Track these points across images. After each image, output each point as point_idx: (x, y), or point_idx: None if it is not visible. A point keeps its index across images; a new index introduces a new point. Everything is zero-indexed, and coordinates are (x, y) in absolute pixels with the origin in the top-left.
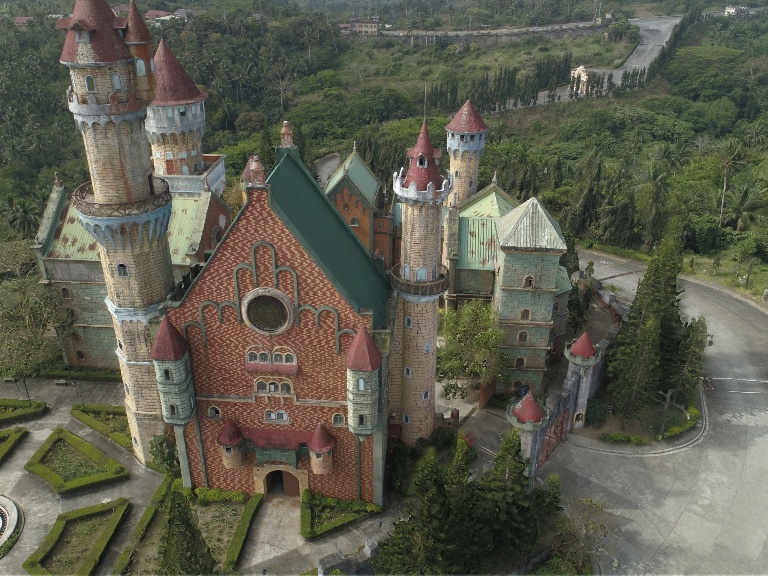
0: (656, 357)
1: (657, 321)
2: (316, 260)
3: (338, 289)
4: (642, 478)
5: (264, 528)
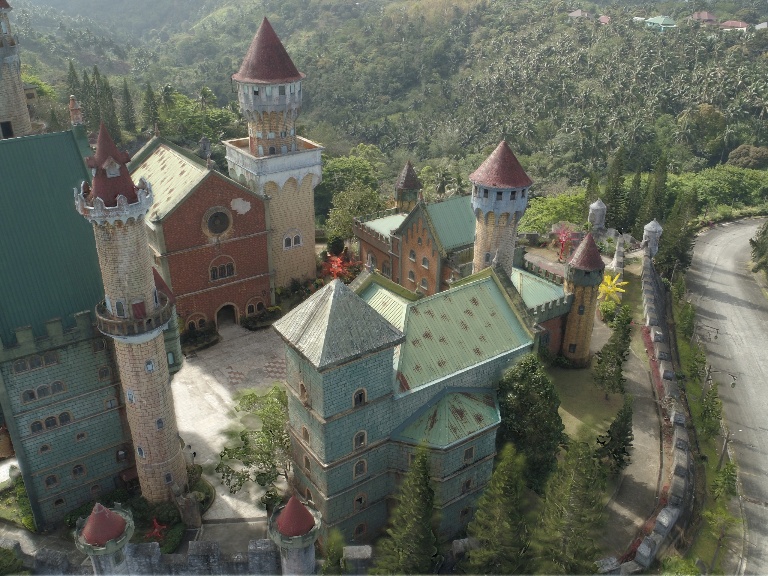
0: None
1: (421, 557)
2: None
3: None
4: None
5: None
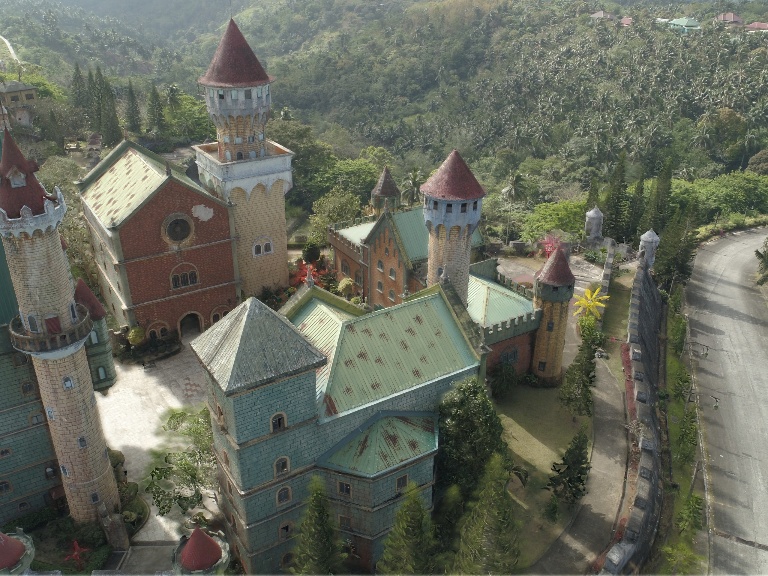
0: None
1: None
2: None
3: None
4: None
5: None
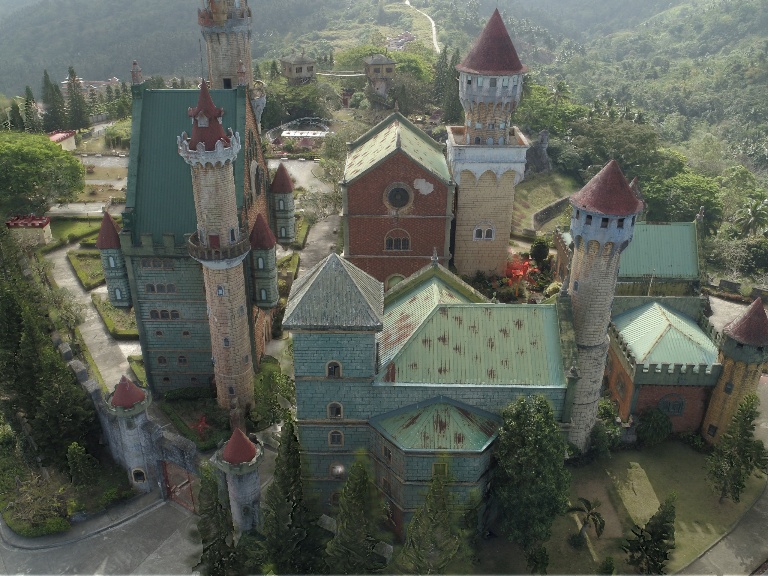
0: (268, 567)
1: None
2: (131, 153)
3: (128, 182)
4: None
5: None
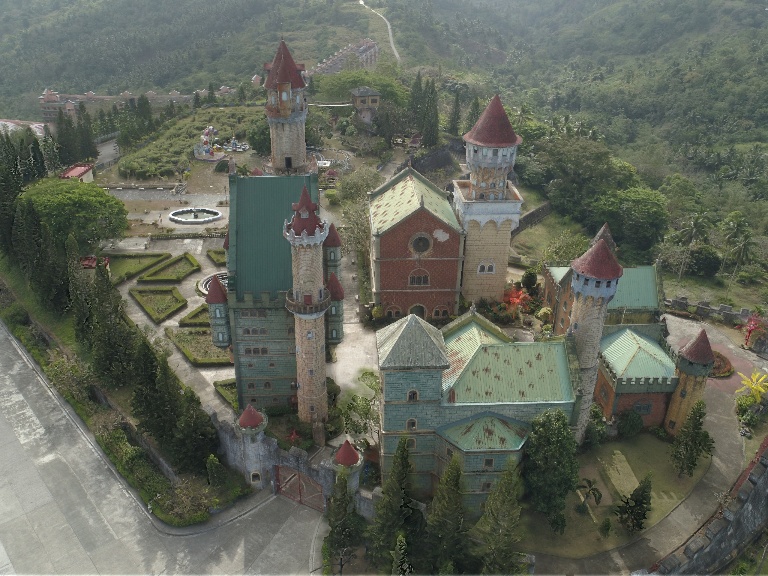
0: (383, 536)
1: None
2: (230, 228)
3: (229, 251)
4: (282, 573)
5: (227, 371)
